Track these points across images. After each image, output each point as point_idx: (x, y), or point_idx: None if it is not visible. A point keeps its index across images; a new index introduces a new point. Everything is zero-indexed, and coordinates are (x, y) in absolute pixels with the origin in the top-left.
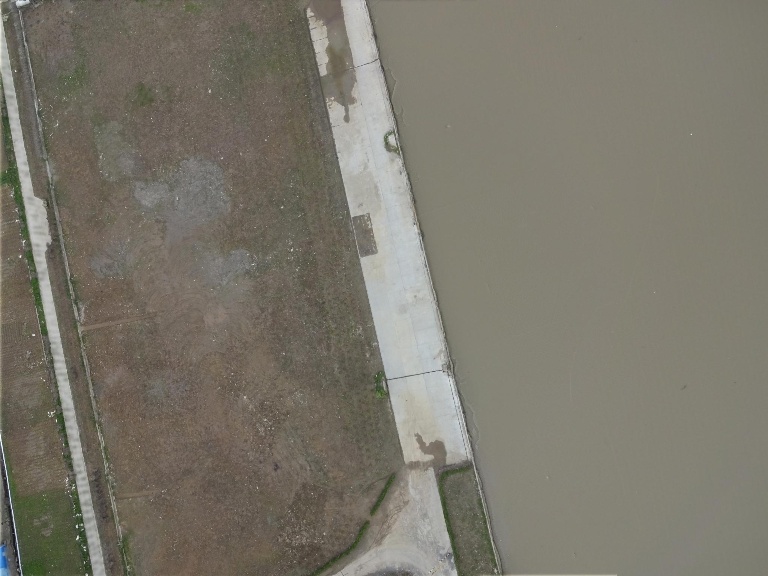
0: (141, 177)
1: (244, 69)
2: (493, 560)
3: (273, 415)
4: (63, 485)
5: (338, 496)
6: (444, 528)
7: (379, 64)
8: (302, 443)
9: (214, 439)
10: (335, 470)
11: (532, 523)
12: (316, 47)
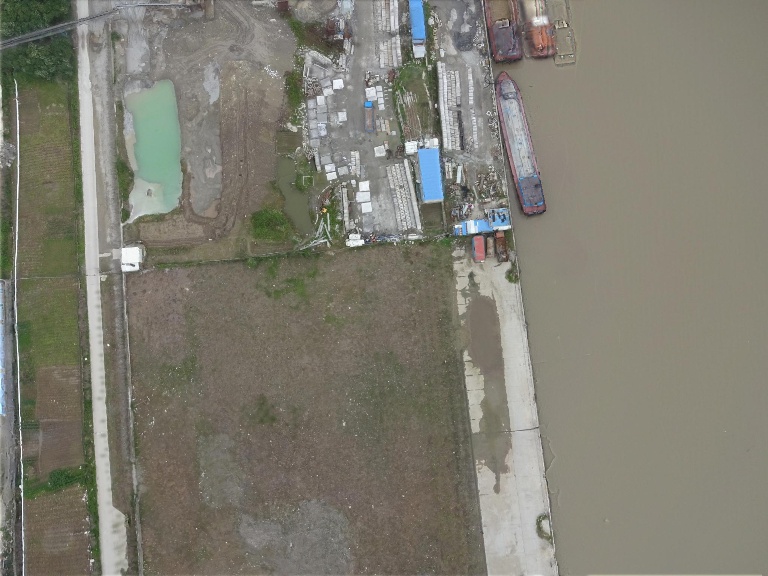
0: (250, 510)
1: (387, 406)
2: None
3: None
4: None
5: None
6: None
7: (539, 434)
8: None
9: None
10: None
11: None
12: (470, 398)
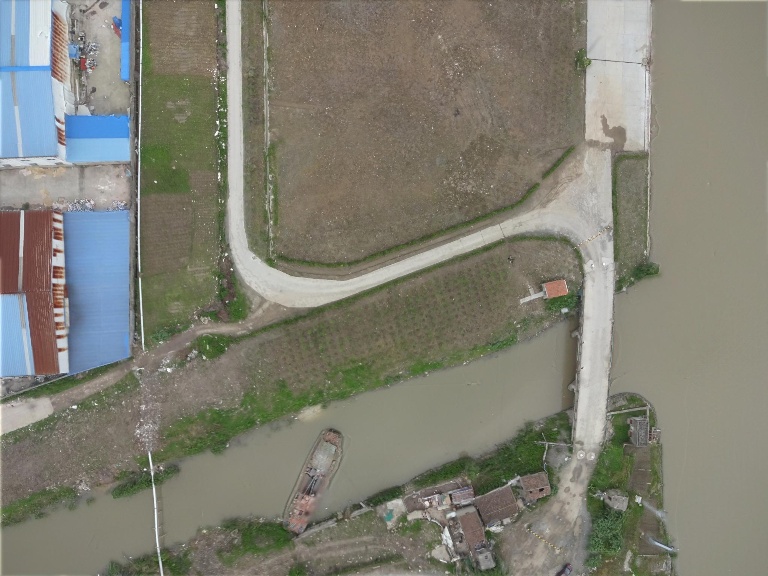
0: None
1: None
2: (646, 242)
3: (465, 62)
4: (210, 75)
5: (514, 154)
6: (609, 204)
7: None
8: (489, 96)
9: (396, 70)
10: (516, 130)
11: (685, 220)
12: None
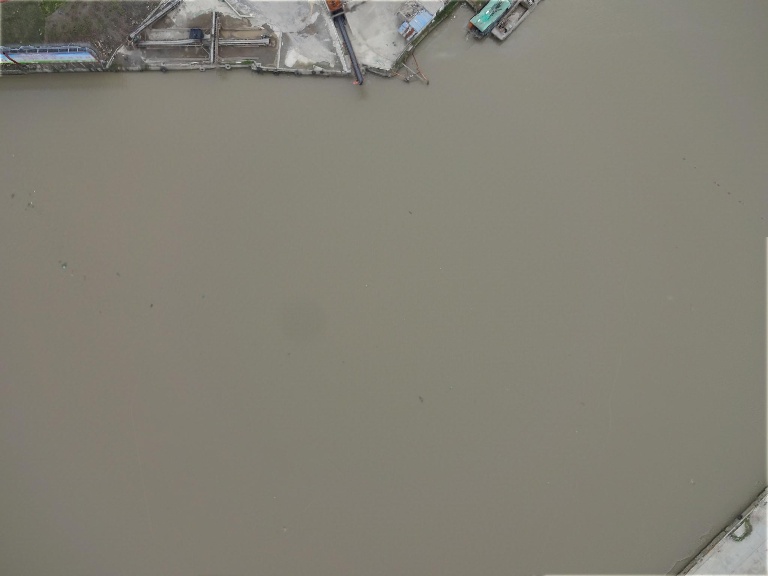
0: None
1: None
2: None
3: None
4: None
5: None
6: None
7: None
8: None
9: None
10: None
11: None
12: None
